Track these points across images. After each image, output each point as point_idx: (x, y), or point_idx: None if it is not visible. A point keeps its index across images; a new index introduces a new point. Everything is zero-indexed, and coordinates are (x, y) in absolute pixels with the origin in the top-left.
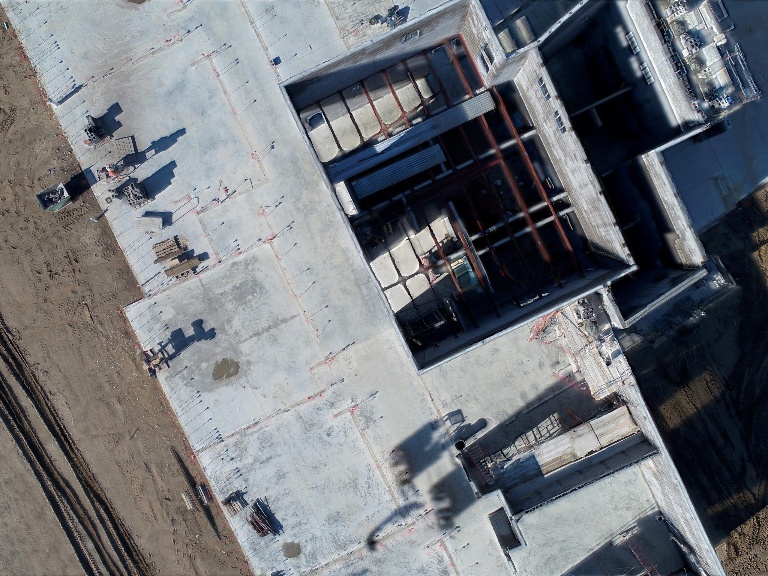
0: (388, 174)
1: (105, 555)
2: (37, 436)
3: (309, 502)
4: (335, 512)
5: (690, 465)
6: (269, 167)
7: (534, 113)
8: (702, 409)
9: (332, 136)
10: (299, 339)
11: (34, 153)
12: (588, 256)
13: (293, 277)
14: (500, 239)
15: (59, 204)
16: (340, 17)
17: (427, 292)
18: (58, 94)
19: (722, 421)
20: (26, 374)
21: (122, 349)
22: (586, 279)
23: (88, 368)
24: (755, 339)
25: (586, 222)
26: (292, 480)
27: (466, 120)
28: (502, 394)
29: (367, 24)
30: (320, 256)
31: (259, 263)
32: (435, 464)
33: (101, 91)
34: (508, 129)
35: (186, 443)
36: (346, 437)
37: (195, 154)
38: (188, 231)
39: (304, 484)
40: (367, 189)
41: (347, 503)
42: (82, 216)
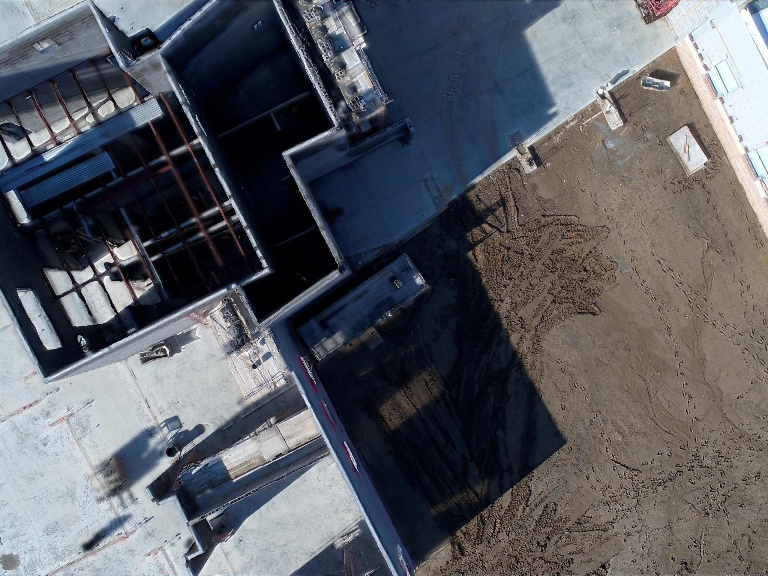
0: (57, 182)
1: None
2: None
3: (27, 513)
4: (54, 522)
5: (412, 466)
6: None
7: None
8: (422, 410)
9: None
10: (13, 349)
11: None
12: None
13: None
14: (173, 245)
15: None
16: None
17: (140, 299)
18: None
19: (443, 421)
20: None
21: None
22: None
23: None
24: (472, 339)
25: None
26: (9, 491)
27: (133, 127)
28: (219, 399)
29: None
30: None
31: None
32: (154, 471)
33: None
34: (179, 135)
35: None
36: (63, 446)
37: None
38: None
39: (21, 495)
40: (37, 197)
41: (66, 513)
42: None
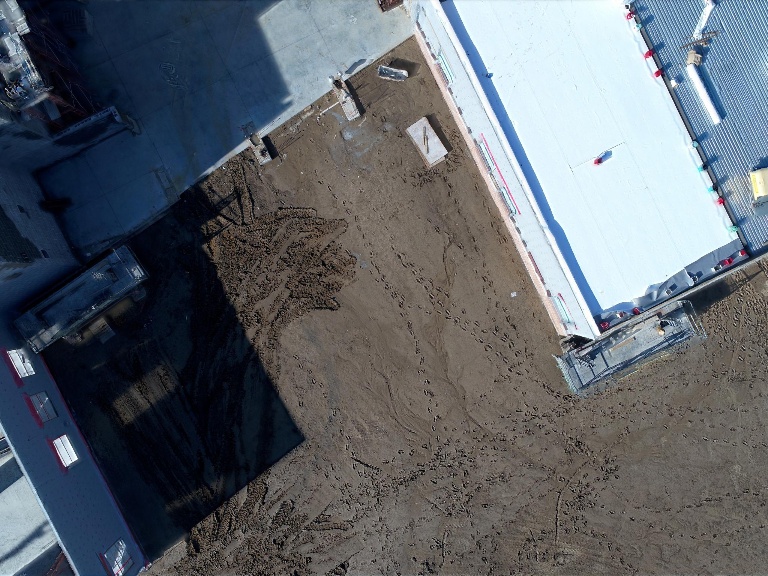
0: None
1: None
2: None
3: None
4: None
5: (146, 461)
6: None
7: None
8: (156, 404)
9: None
10: None
11: None
12: None
13: None
14: None
15: None
16: None
17: None
18: None
19: (177, 416)
20: None
21: None
22: None
23: None
24: (207, 333)
25: None
26: None
27: None
28: None
29: None
30: None
31: None
32: None
33: None
34: None
35: None
36: None
37: None
38: None
39: None
40: None
41: None
42: None
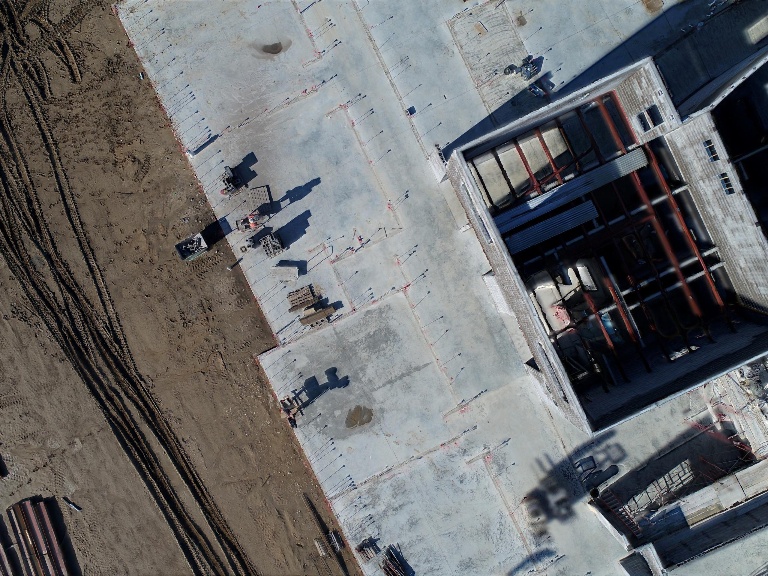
0: (541, 230)
1: None
2: (169, 483)
3: (441, 548)
4: (467, 558)
5: None
6: (403, 216)
7: (687, 170)
8: None
9: None
10: (432, 387)
11: (168, 202)
12: (731, 308)
13: (426, 325)
14: (651, 294)
15: (196, 254)
16: (474, 67)
17: (560, 340)
18: (194, 144)
19: None
20: (158, 421)
21: (255, 397)
22: (740, 335)
23: (221, 415)
24: None
25: (739, 278)
26: (424, 527)
27: (619, 176)
28: (634, 441)
29: (501, 74)
30: (453, 304)
31: (393, 311)
32: (567, 510)
33: (236, 141)
34: (659, 184)
35: (318, 490)
36: (478, 484)
37: (329, 203)
38: (322, 280)
39: (436, 530)
40: (520, 245)
41: (479, 549)
42: (216, 265)
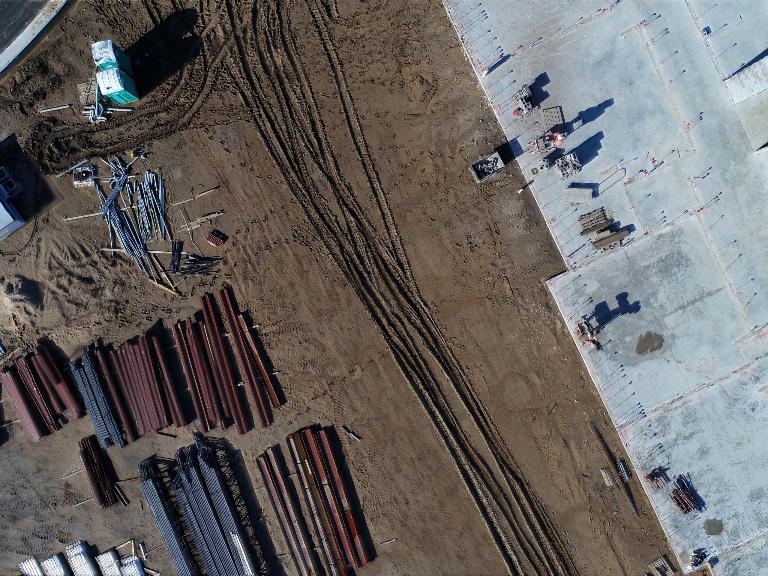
0: None
1: (519, 533)
2: (452, 411)
3: (732, 478)
4: (758, 488)
5: None
6: (697, 138)
7: None
8: None
9: (761, 107)
10: (725, 312)
11: (457, 123)
12: None
13: (720, 249)
14: None
15: None
16: None
17: None
18: (486, 63)
19: None
20: (441, 348)
21: (543, 322)
22: None
23: (506, 342)
24: None
25: None
26: (715, 456)
27: None
28: None
29: None
30: (747, 228)
31: (685, 235)
32: None
33: (529, 61)
34: None
35: (606, 418)
36: None
37: (623, 124)
38: (614, 202)
39: (727, 460)
40: None
41: None
42: (505, 187)
